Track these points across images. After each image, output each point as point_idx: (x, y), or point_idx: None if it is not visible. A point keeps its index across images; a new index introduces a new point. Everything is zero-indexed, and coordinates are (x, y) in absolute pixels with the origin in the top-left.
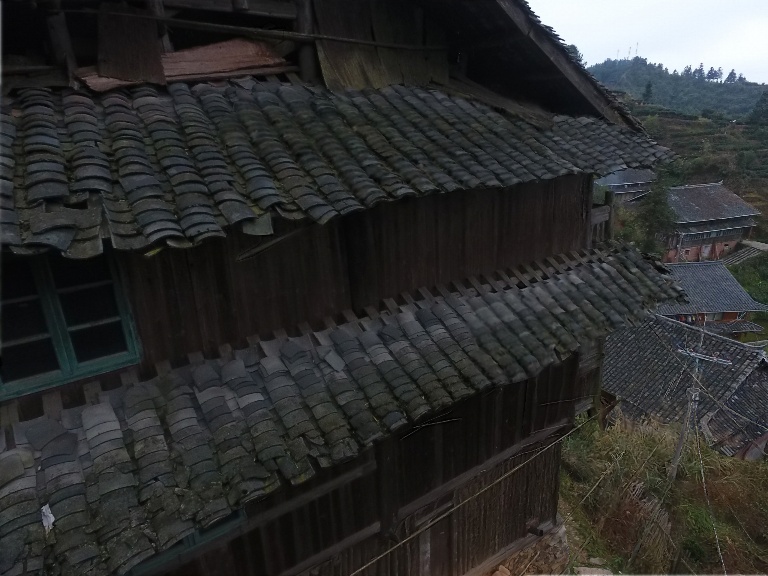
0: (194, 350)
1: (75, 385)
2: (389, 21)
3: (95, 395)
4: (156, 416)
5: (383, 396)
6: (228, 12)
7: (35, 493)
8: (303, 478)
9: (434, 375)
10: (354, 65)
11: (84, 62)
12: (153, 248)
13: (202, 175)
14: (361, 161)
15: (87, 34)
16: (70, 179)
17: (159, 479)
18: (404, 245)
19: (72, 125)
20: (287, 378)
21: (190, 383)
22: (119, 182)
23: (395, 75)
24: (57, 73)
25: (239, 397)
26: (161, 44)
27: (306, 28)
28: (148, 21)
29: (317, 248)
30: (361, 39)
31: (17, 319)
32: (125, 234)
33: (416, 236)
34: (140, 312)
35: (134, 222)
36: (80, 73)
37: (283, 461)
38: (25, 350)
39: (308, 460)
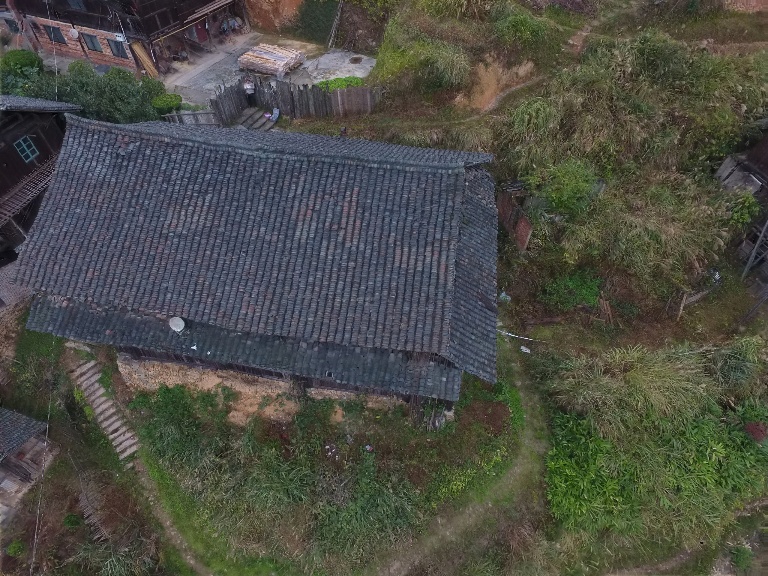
0: None
1: None
2: None
3: None
4: None
5: None
6: None
7: None
8: None
9: None
10: None
11: None
12: None
13: None
14: None
15: None
16: None
17: None
18: None
19: None
20: None
21: None
22: None
23: None
24: None
25: None
26: None
27: None
28: None
29: None
30: None
31: None
32: None
33: None
34: None
35: None
36: None
37: None
38: None
39: None
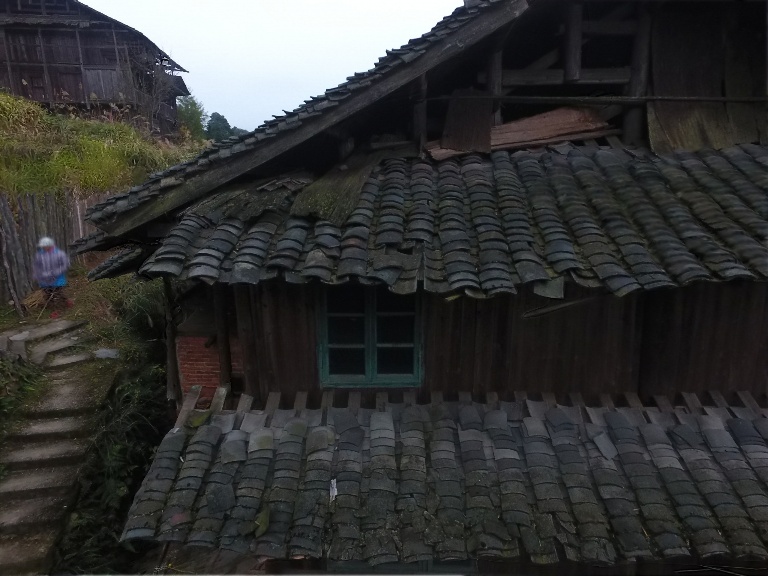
0: (465, 389)
1: (371, 391)
2: (750, 72)
3: (383, 404)
4: (423, 439)
5: (661, 508)
6: (558, 85)
7: (330, 466)
8: (544, 560)
9: (743, 510)
10: (691, 124)
11: (432, 137)
12: (453, 294)
13: (506, 234)
14: (681, 232)
15: (439, 115)
16: (405, 230)
17: (414, 496)
18: (724, 334)
19: (414, 187)
20: (547, 446)
21: (455, 419)
22: (438, 235)
23: (747, 132)
24: (412, 147)
25: (496, 448)
26: (493, 118)
27: (638, 91)
28: (487, 100)
29: (607, 318)
30: (706, 96)
31: (348, 329)
32: (434, 279)
33: (745, 326)
34: (429, 344)
35: (443, 270)
36: (428, 146)
37: (527, 531)
38: (347, 353)
39: (554, 543)
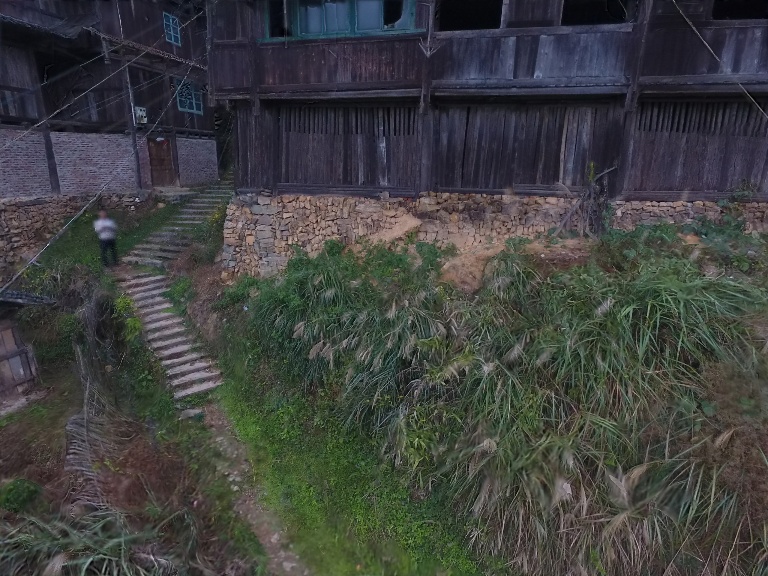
0: None
1: None
2: None
3: None
4: None
5: None
6: None
7: None
8: None
9: None
10: None
11: None
12: None
13: None
14: None
15: None
16: None
17: None
18: None
19: None
20: None
21: None
22: None
23: None
24: None
25: None
26: None
27: None
28: None
29: None
30: None
31: None
32: None
33: None
34: None
35: None
36: None
37: None
38: None
39: None
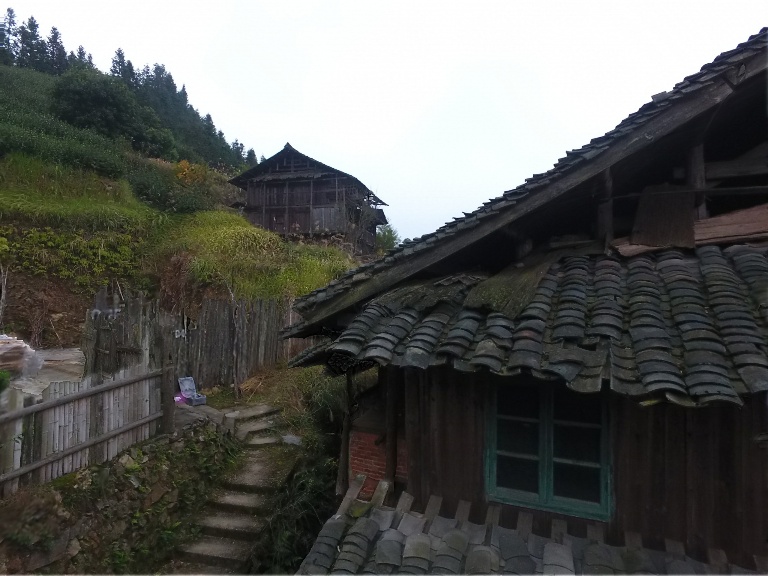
0: (674, 537)
1: (546, 515)
2: None
3: (560, 534)
4: None
5: None
6: None
7: None
8: None
9: None
10: None
11: (620, 234)
12: (649, 398)
13: (721, 334)
14: None
15: (627, 213)
16: (587, 325)
17: None
18: None
19: (599, 283)
20: None
21: (661, 575)
22: (629, 332)
23: None
24: (597, 245)
25: None
26: (696, 213)
27: None
28: (686, 194)
29: None
30: None
31: (520, 435)
32: (624, 379)
33: None
34: (621, 467)
35: (635, 369)
36: (615, 243)
37: None
38: (518, 464)
39: None
